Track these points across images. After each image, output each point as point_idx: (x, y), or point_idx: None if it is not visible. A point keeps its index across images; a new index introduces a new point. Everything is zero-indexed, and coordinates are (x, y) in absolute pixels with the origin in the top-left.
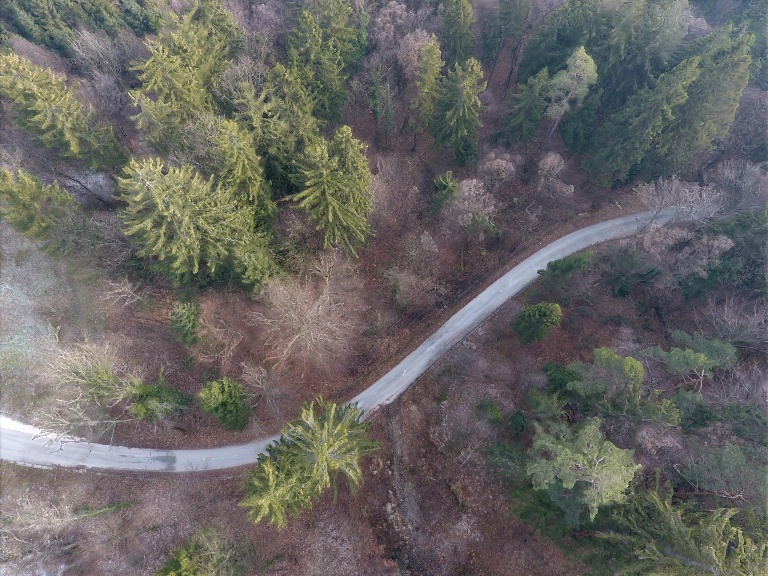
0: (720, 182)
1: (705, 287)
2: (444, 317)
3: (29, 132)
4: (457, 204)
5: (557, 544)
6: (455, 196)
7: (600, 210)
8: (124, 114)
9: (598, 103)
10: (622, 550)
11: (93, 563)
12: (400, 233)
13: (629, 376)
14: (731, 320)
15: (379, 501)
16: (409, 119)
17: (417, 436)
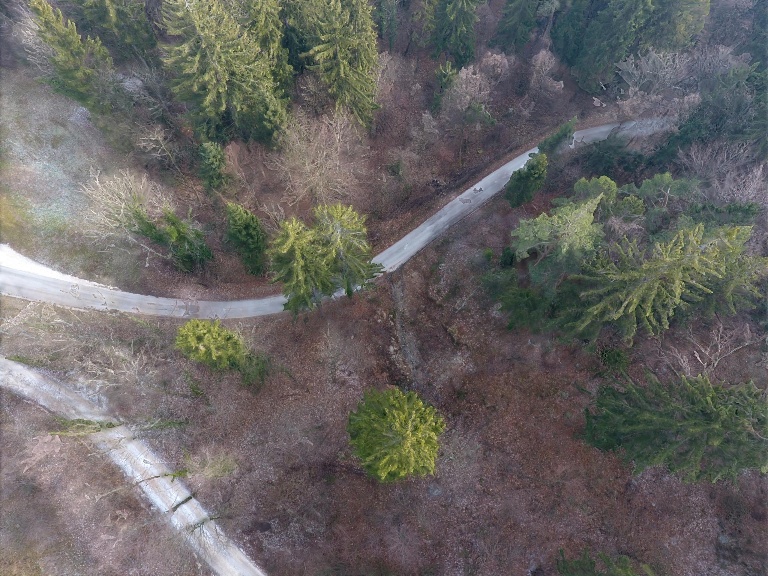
0: (696, 69)
1: (678, 149)
2: (443, 202)
3: (72, 3)
4: (456, 89)
5: (542, 366)
6: (454, 84)
7: (589, 118)
8: (153, 5)
9: (586, 4)
10: (591, 302)
11: (127, 383)
12: (403, 142)
13: (603, 189)
14: (697, 157)
15: (383, 342)
16: (412, 33)
17: (417, 297)
